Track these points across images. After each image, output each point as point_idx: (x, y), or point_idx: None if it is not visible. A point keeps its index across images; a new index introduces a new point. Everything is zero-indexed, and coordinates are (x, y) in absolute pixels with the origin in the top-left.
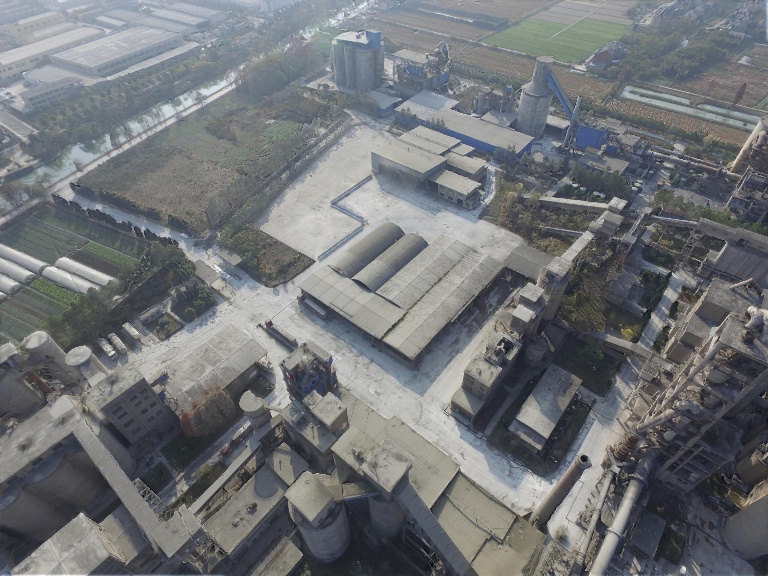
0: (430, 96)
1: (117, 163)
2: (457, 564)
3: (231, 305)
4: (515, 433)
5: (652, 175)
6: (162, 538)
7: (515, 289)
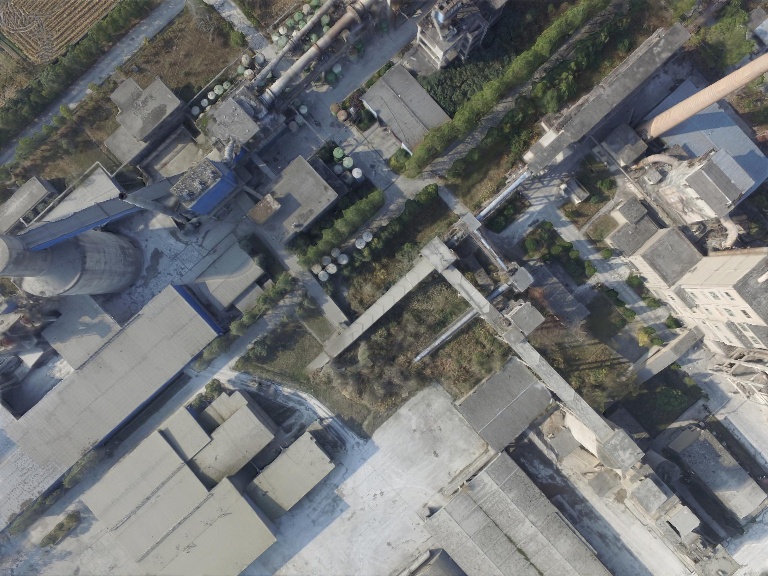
0: None
1: None
2: None
3: None
4: None
5: None
6: None
7: (529, 437)
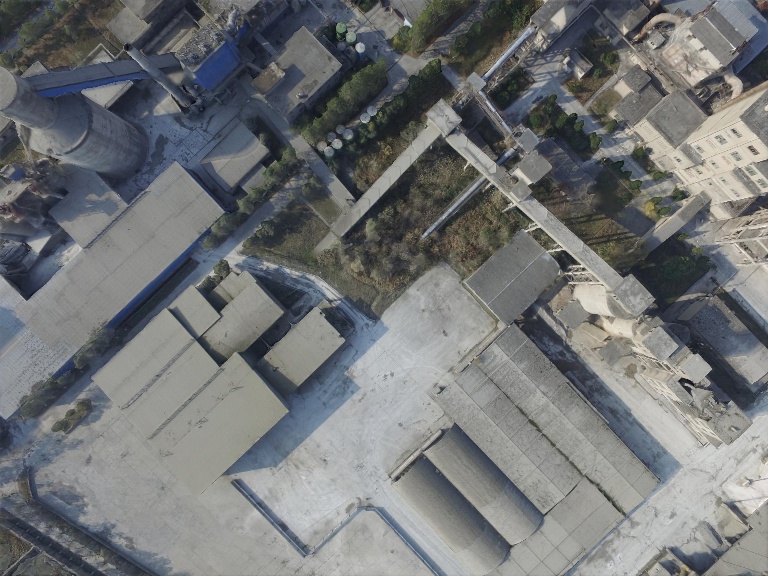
0: None
1: None
2: None
3: None
4: None
5: None
6: None
7: (538, 314)
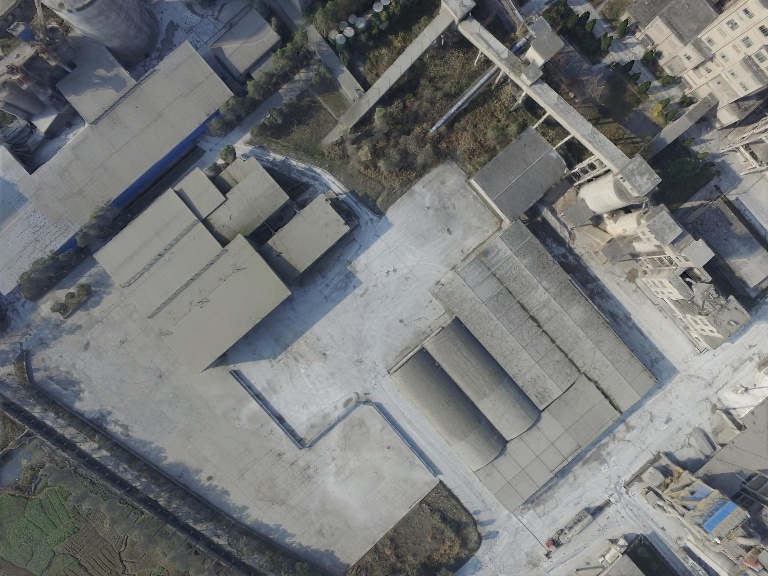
0: None
1: None
2: None
3: None
4: None
5: None
6: None
7: (543, 215)
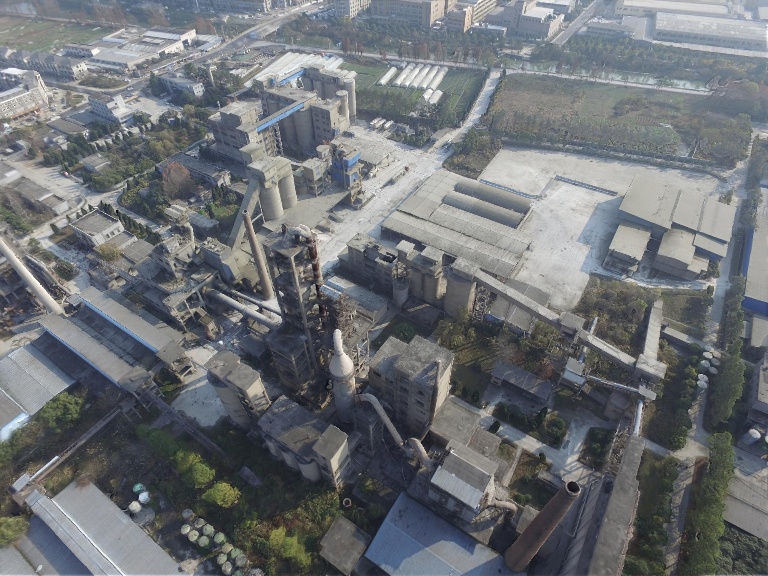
0: None
1: (541, 78)
2: (234, 230)
3: (421, 154)
4: (325, 278)
5: None
6: (243, 125)
7: None
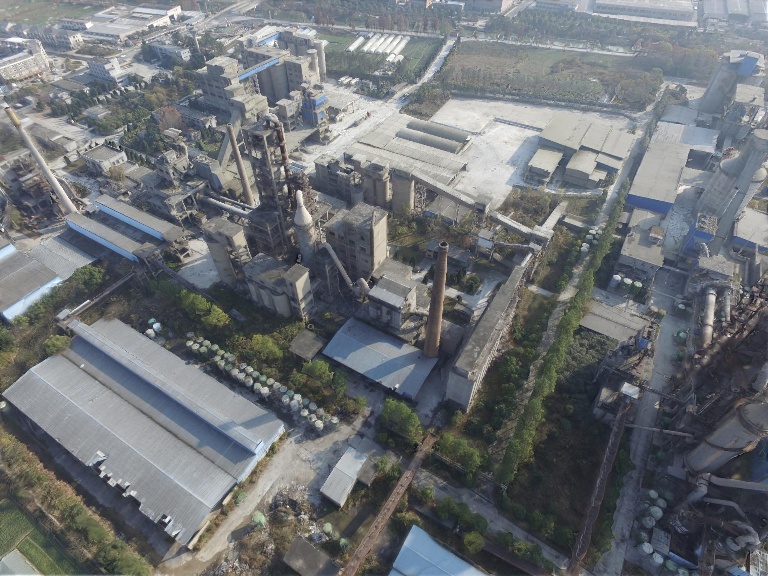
0: (707, 135)
1: (490, 44)
2: (221, 154)
3: (381, 104)
4: None
5: (687, 317)
6: (227, 73)
7: None
